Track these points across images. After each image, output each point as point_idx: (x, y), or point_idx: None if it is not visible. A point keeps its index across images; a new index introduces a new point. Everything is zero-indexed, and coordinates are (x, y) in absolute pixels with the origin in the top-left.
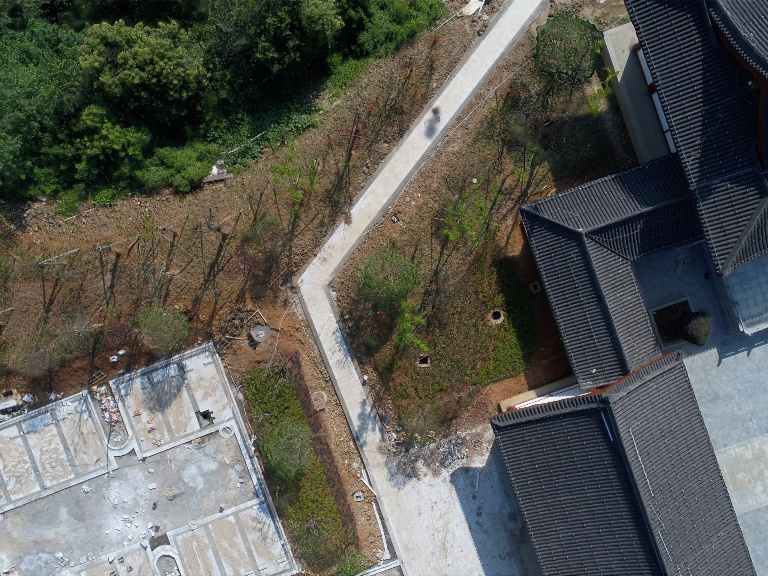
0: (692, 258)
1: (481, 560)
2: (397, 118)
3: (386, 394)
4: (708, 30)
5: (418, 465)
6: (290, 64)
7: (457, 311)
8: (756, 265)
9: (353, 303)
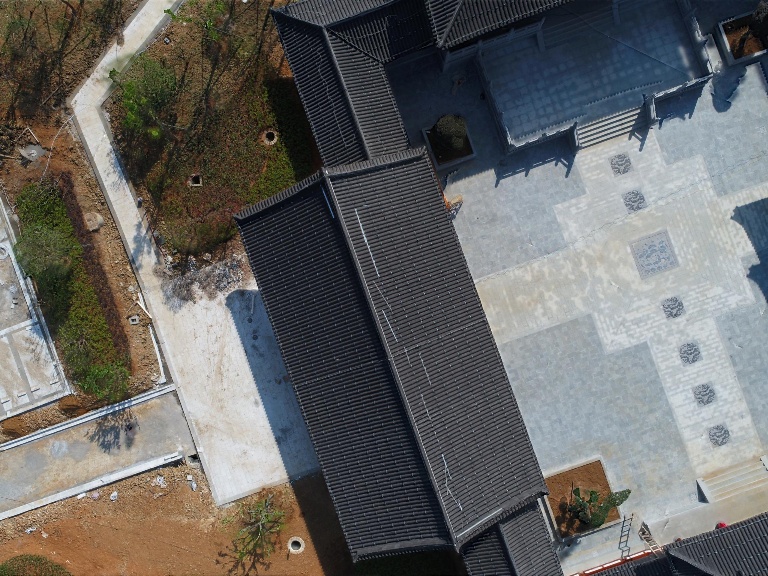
0: (468, 79)
1: (257, 384)
2: None
3: (159, 215)
4: None
5: (194, 288)
6: None
7: (229, 130)
8: (528, 81)
9: None
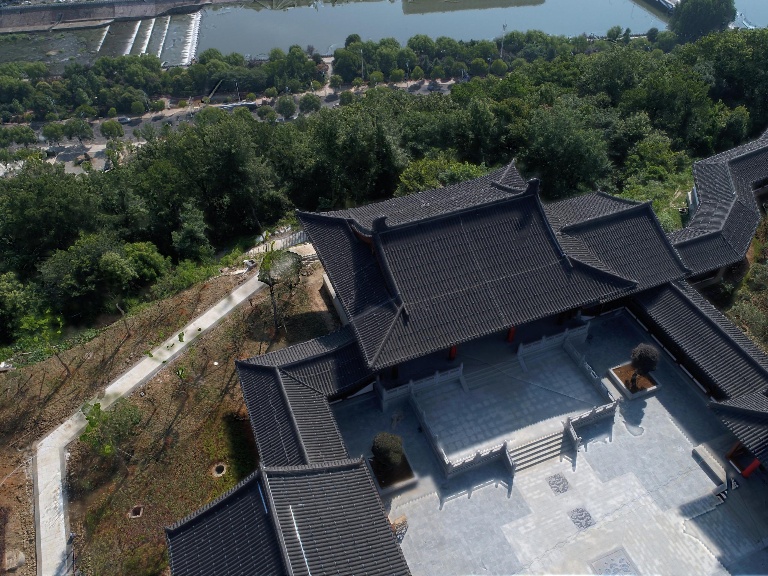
0: (405, 416)
1: None
2: (163, 328)
3: (88, 550)
4: (352, 235)
5: None
6: (90, 298)
7: (180, 464)
8: (458, 415)
9: (82, 460)
